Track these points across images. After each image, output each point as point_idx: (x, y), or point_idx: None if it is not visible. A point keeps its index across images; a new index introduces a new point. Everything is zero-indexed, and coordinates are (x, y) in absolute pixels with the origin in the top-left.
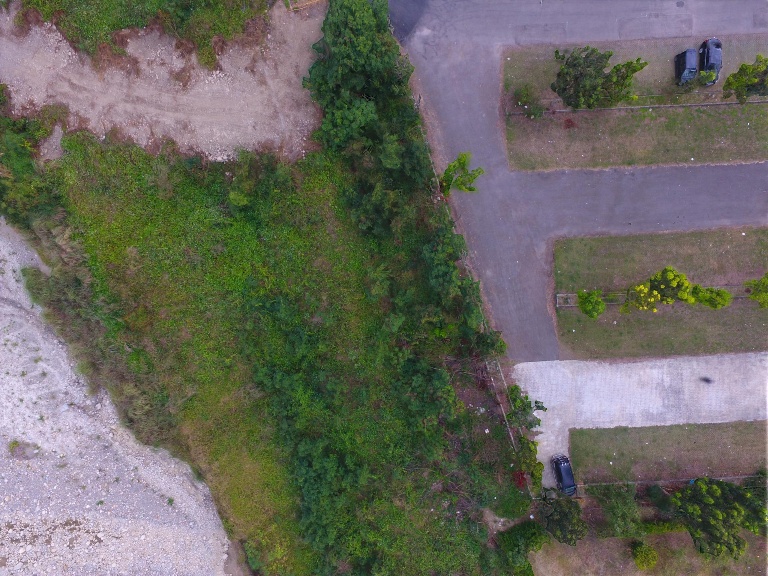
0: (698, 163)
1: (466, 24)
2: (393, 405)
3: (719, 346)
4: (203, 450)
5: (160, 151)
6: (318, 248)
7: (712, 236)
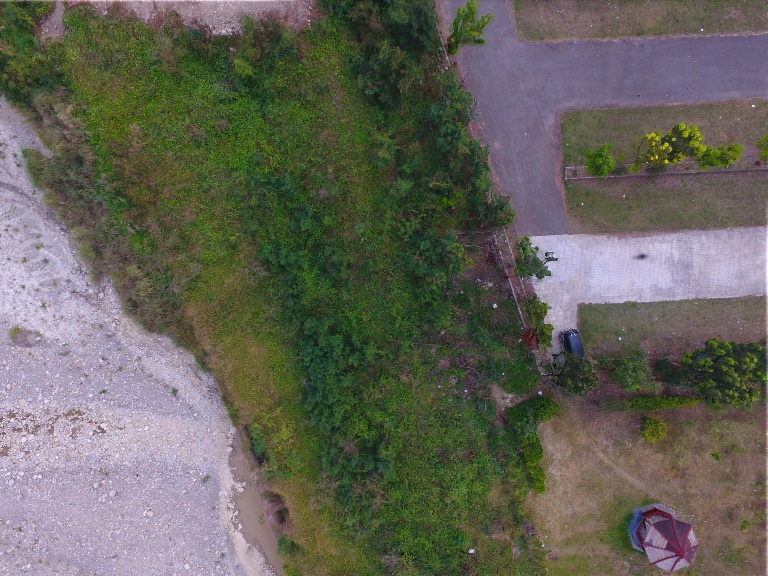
0: (708, 34)
1: None
2: (400, 279)
3: (729, 220)
4: (208, 332)
5: (163, 25)
6: (324, 119)
7: (722, 108)
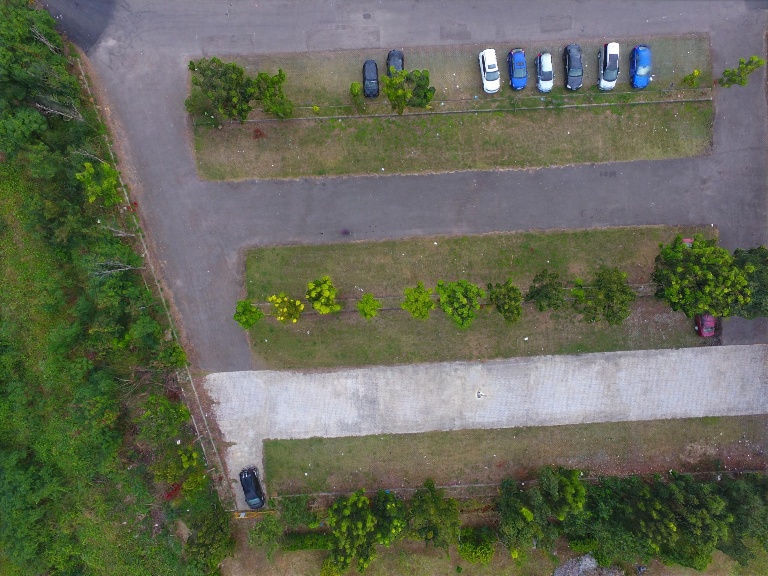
0: (389, 173)
1: (152, 35)
2: None
3: (413, 356)
4: None
5: None
6: (5, 258)
7: (404, 246)
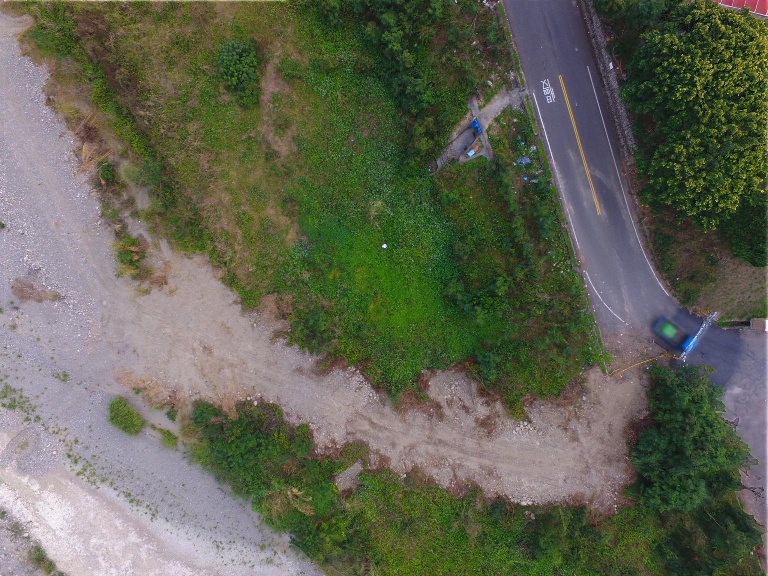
0: None
1: None
2: None
3: None
4: None
5: (463, 493)
6: None
7: None
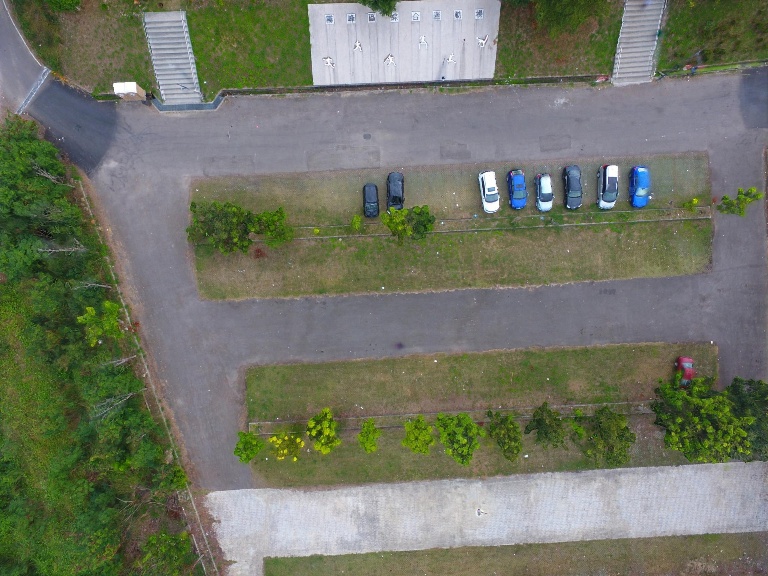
0: (389, 291)
1: (153, 156)
2: None
3: (414, 473)
4: None
5: None
6: (7, 378)
7: (405, 363)
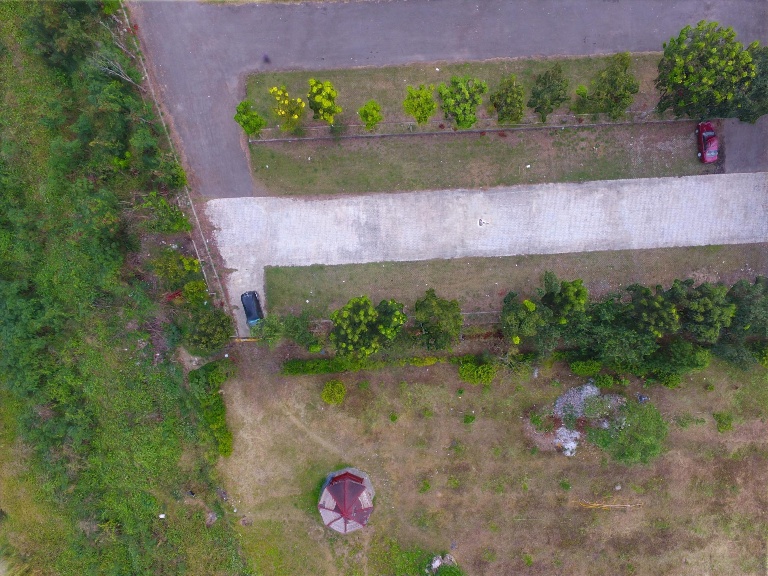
0: None
1: None
2: (82, 240)
3: (415, 183)
4: None
5: None
6: (5, 81)
7: (406, 72)
